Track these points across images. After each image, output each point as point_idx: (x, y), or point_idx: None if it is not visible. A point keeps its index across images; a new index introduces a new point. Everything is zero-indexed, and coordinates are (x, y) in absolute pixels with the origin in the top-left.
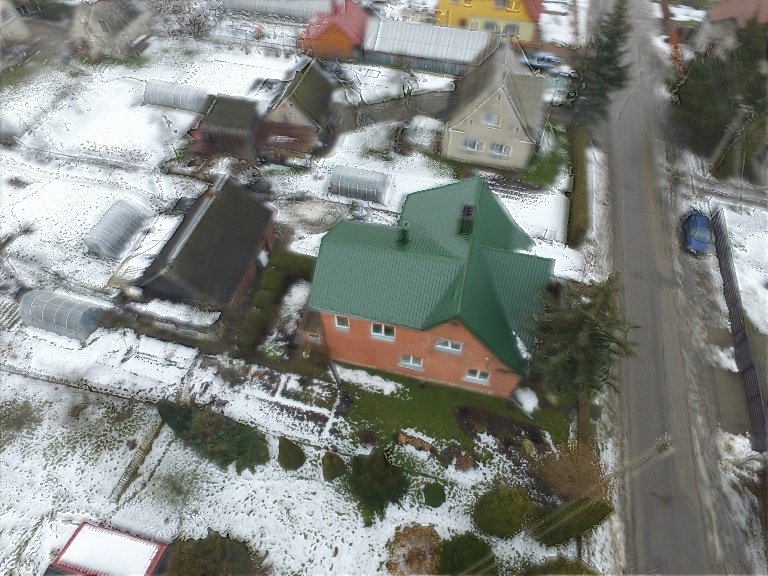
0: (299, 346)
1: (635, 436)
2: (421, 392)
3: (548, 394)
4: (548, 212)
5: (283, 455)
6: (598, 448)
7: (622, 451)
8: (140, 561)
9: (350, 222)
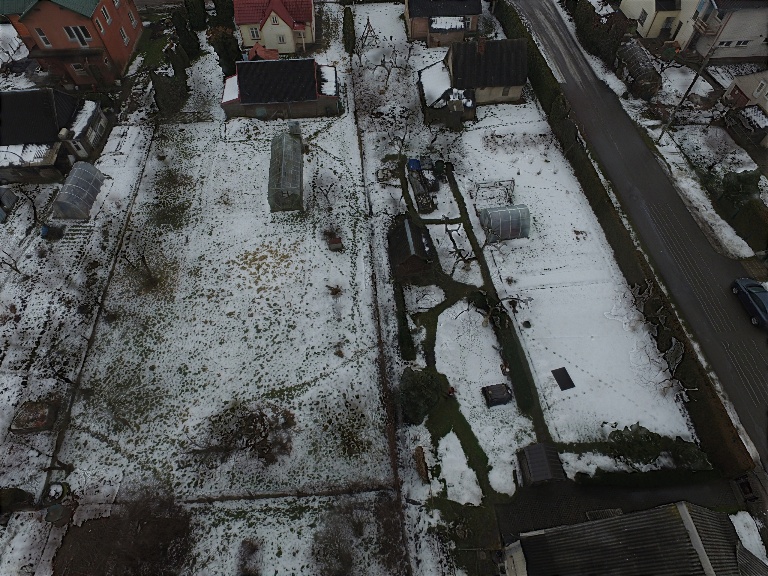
0: (112, 89)
1: (161, 1)
2: (142, 50)
3: (142, 17)
4: (8, 28)
5: (178, 59)
6: (168, 8)
7: (168, 3)
8: (232, 79)
9: (23, 14)
